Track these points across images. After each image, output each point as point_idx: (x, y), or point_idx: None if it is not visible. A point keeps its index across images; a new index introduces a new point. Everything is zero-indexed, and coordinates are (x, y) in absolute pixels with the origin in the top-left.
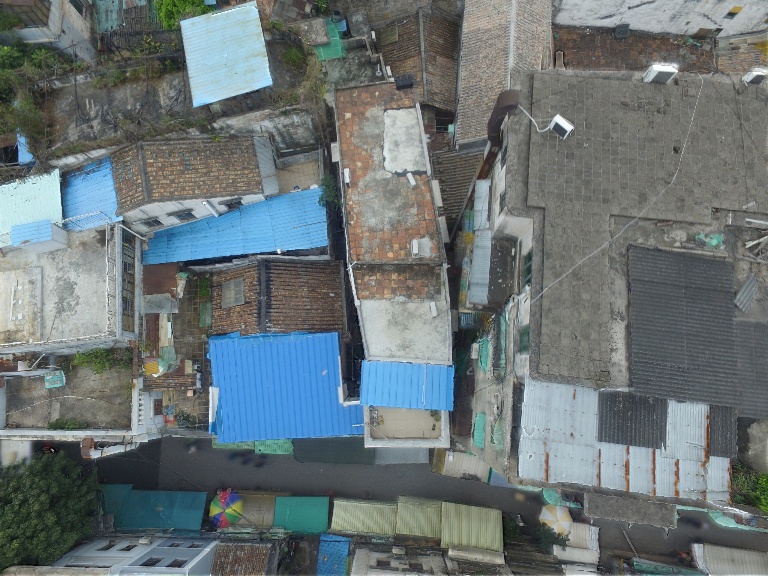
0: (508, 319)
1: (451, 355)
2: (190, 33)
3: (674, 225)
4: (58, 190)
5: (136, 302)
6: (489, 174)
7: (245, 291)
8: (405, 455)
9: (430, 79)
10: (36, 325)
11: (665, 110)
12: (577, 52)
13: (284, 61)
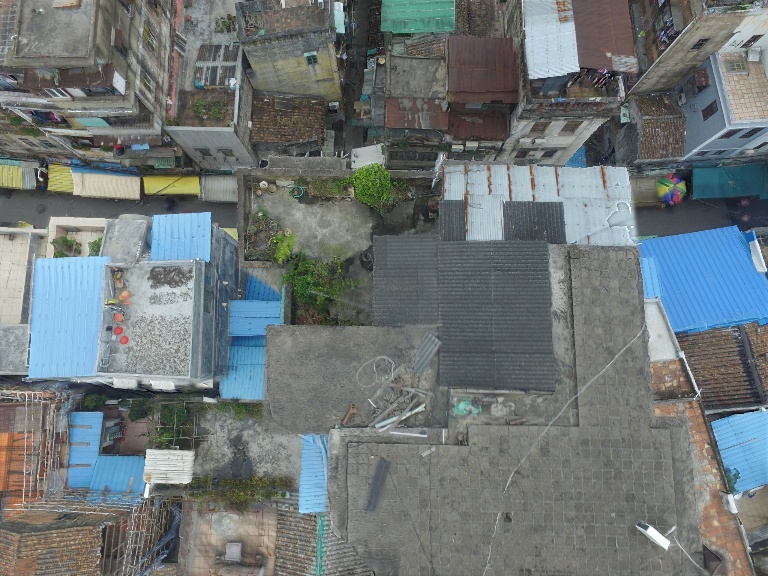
0: None
1: None
2: None
3: (508, 421)
4: None
5: None
6: None
7: None
8: None
9: None
10: None
11: (522, 575)
12: None
13: None
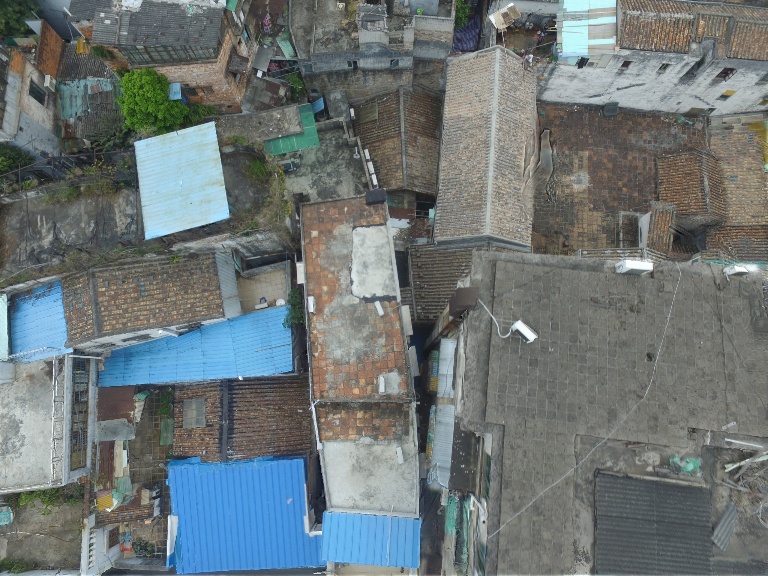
0: (469, 519)
1: (418, 507)
2: (144, 156)
3: (646, 447)
4: (5, 318)
5: (89, 432)
6: (455, 333)
7: (207, 412)
8: None
9: (410, 162)
10: None
11: (639, 308)
12: (564, 129)
13: (247, 175)
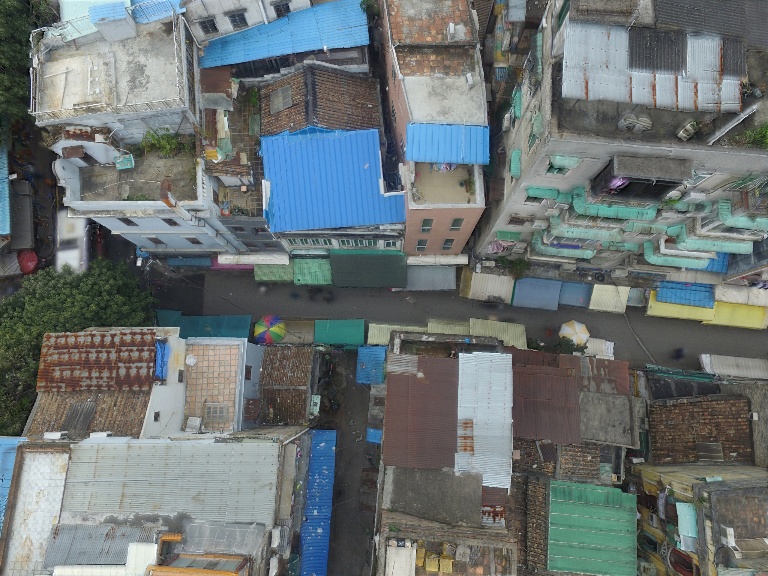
0: (545, 23)
1: (486, 117)
2: None
3: None
4: None
5: (196, 95)
6: None
7: (292, 96)
8: (434, 281)
9: None
10: (112, 98)
11: None
12: None
13: None
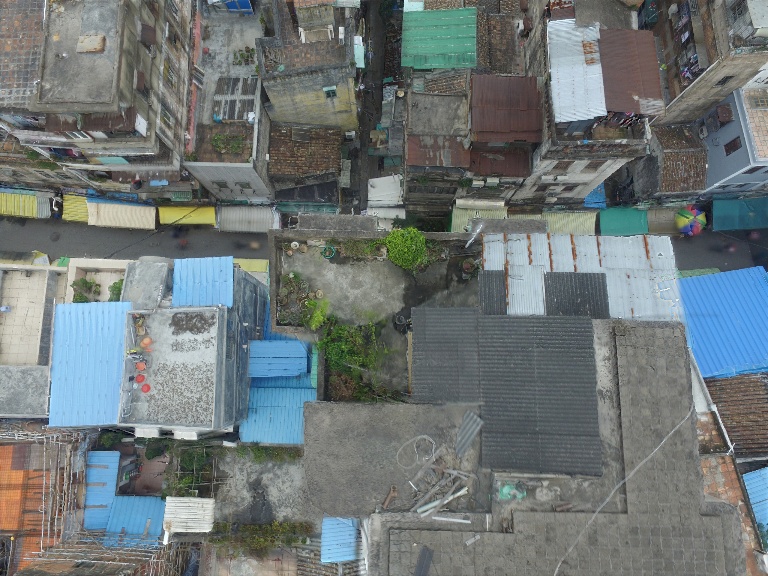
0: None
1: None
2: None
3: (554, 507)
4: None
5: None
6: None
7: None
8: None
9: None
10: None
11: None
12: None
13: None
